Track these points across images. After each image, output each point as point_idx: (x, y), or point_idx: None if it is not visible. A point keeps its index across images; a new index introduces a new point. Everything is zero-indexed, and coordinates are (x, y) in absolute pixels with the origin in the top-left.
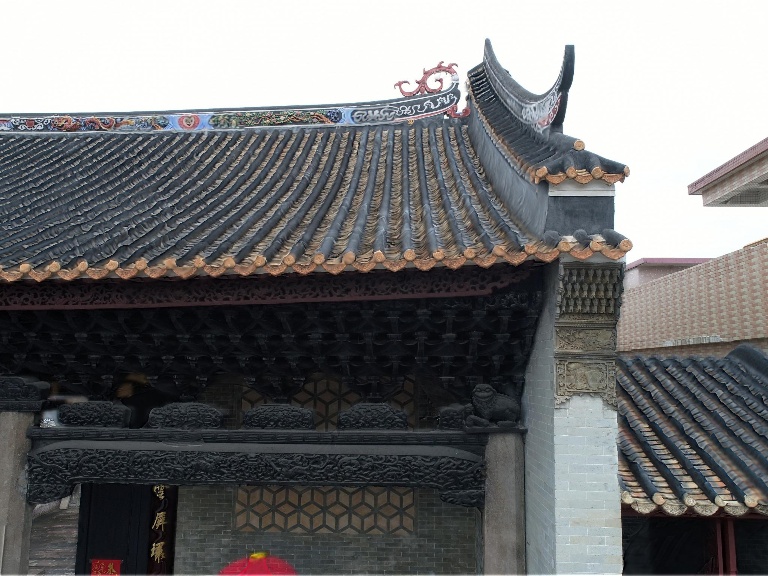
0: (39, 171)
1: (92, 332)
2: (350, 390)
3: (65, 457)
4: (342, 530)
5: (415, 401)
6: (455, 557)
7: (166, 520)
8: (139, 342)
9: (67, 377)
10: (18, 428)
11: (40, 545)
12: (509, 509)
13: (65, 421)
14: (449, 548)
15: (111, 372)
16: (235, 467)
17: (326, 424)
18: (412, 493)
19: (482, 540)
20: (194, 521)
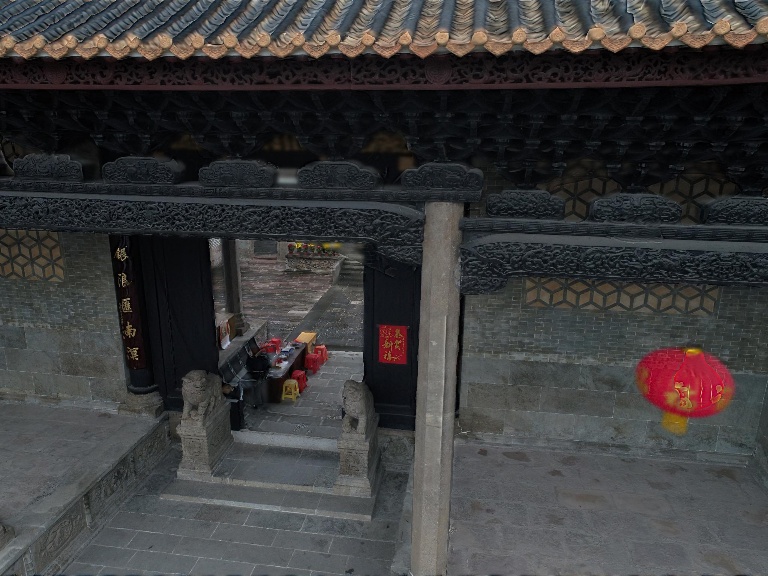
0: None
1: (581, 113)
2: None
3: (507, 251)
4: (637, 309)
5: None
6: (754, 338)
7: None
8: (638, 126)
9: (508, 164)
10: (453, 220)
11: None
12: None
13: (494, 212)
14: (750, 329)
15: (568, 159)
16: (704, 267)
17: None
18: None
19: None
20: (483, 295)
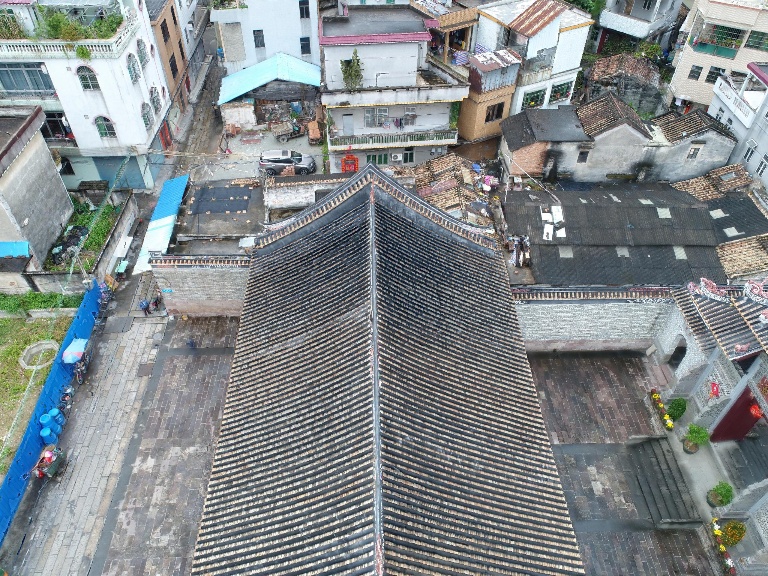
0: (322, 401)
1: None
2: None
3: None
4: None
5: None
6: None
7: None
8: None
9: None
10: None
11: (571, 385)
12: None
13: None
14: None
15: None
16: None
17: None
18: None
19: None
20: None
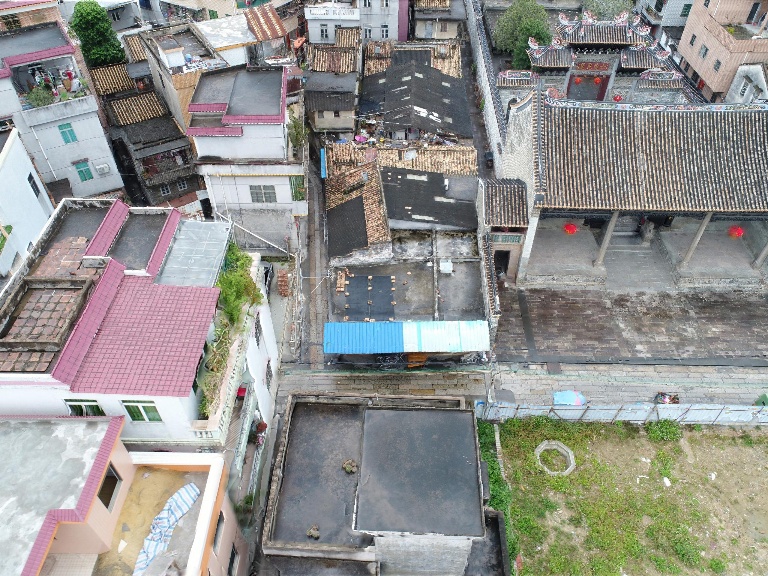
0: None
1: None
2: None
3: None
4: None
5: None
6: None
7: None
8: None
9: None
10: None
11: None
12: None
13: None
14: None
15: None
16: (746, 219)
17: None
18: None
19: (761, 211)
20: None
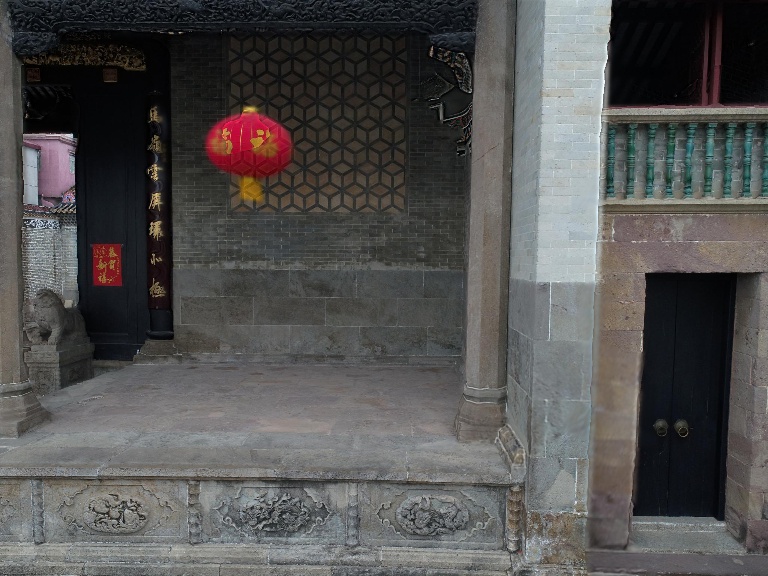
0: None
1: None
2: (340, 72)
3: None
4: (335, 209)
5: (407, 82)
6: (444, 233)
7: (162, 200)
8: None
9: None
10: None
11: None
12: (499, 42)
13: None
14: (439, 224)
15: None
16: (222, 5)
17: (317, 106)
18: (403, 173)
19: None
20: (189, 202)
